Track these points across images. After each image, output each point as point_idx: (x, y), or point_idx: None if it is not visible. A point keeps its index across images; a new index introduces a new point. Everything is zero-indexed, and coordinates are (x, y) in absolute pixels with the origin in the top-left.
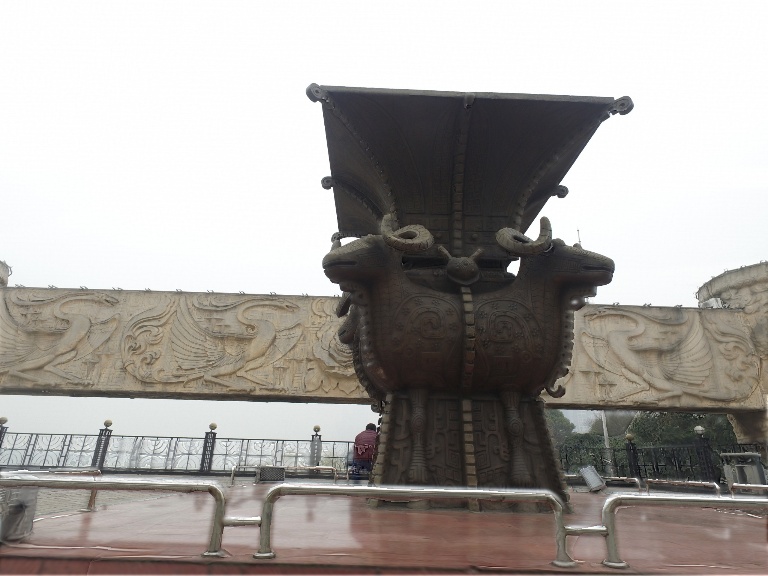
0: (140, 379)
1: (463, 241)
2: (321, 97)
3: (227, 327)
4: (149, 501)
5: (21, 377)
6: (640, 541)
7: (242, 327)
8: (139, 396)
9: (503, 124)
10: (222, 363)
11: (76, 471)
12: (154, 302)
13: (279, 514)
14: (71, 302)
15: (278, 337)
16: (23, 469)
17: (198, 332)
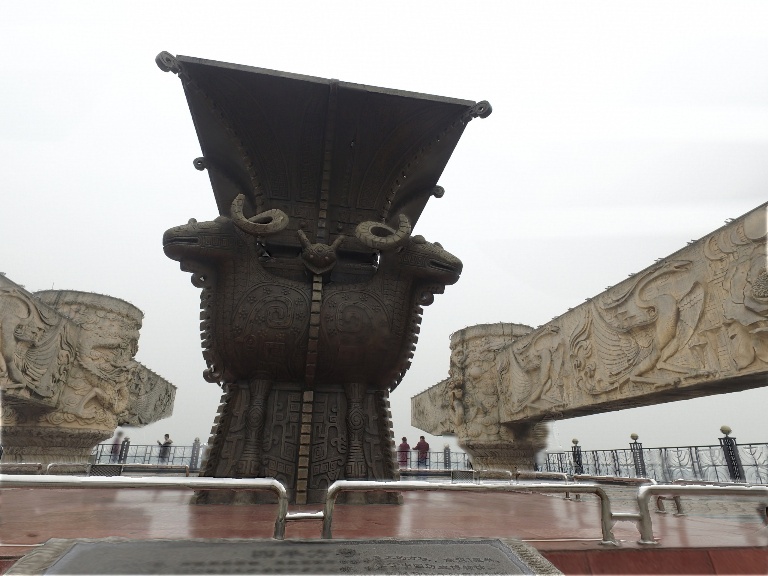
0: (589, 393)
1: (258, 251)
2: None
3: (633, 318)
4: None
5: (533, 407)
6: (3, 501)
7: (645, 312)
8: (613, 408)
9: (218, 147)
10: (639, 359)
11: (627, 484)
12: (577, 318)
13: None
14: (538, 340)
15: (681, 309)
16: (596, 481)
17: (611, 333)
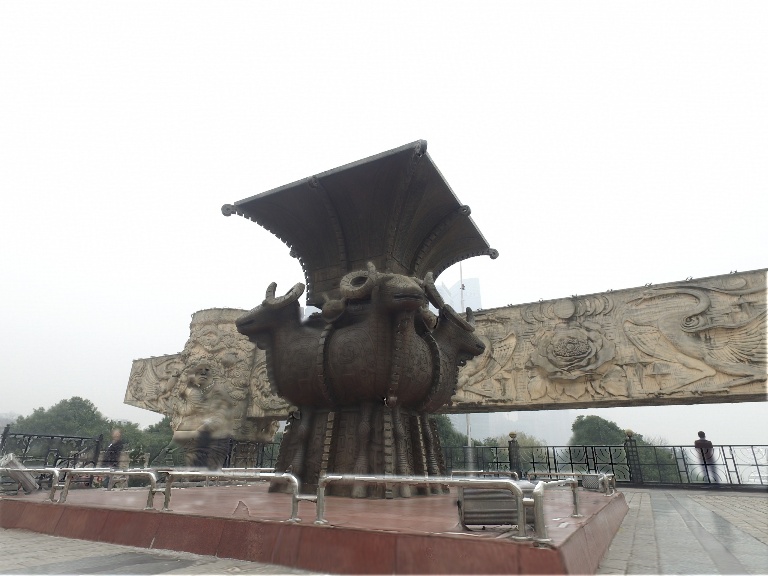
0: None
1: None
2: None
3: None
4: (603, 499)
5: None
6: None
7: None
8: None
9: None
10: None
11: None
12: None
13: None
14: None
15: None
16: None
17: None
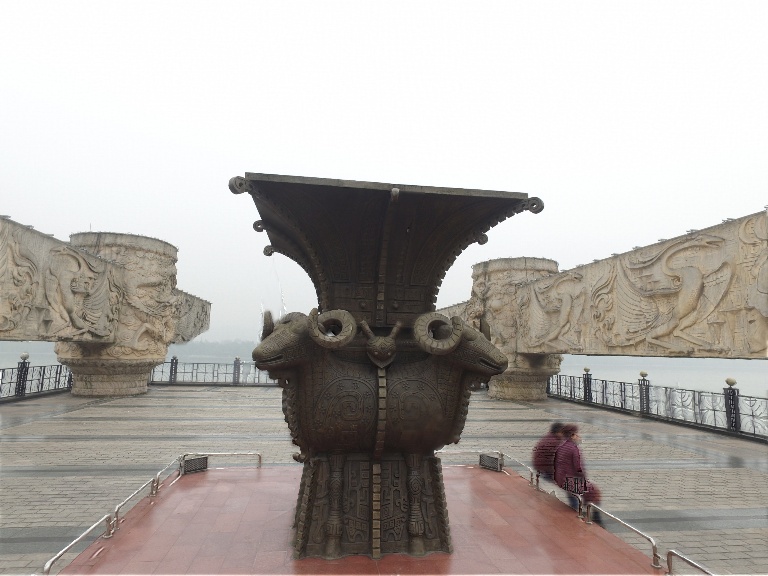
0: (605, 344)
1: None
2: (268, 253)
3: (657, 283)
4: None
5: (550, 345)
6: None
7: None
8: None
9: (279, 221)
10: (657, 323)
11: (631, 414)
12: (602, 271)
13: (261, 489)
14: (560, 284)
15: (706, 285)
16: (602, 407)
17: (634, 293)
